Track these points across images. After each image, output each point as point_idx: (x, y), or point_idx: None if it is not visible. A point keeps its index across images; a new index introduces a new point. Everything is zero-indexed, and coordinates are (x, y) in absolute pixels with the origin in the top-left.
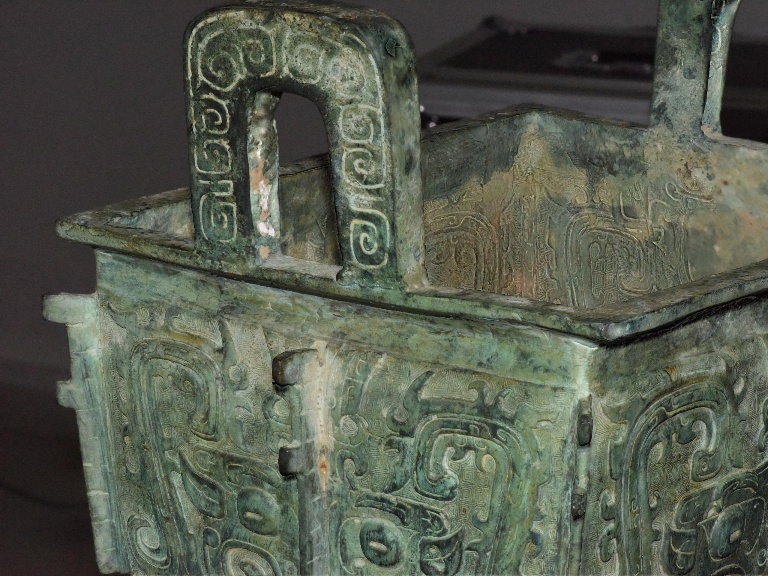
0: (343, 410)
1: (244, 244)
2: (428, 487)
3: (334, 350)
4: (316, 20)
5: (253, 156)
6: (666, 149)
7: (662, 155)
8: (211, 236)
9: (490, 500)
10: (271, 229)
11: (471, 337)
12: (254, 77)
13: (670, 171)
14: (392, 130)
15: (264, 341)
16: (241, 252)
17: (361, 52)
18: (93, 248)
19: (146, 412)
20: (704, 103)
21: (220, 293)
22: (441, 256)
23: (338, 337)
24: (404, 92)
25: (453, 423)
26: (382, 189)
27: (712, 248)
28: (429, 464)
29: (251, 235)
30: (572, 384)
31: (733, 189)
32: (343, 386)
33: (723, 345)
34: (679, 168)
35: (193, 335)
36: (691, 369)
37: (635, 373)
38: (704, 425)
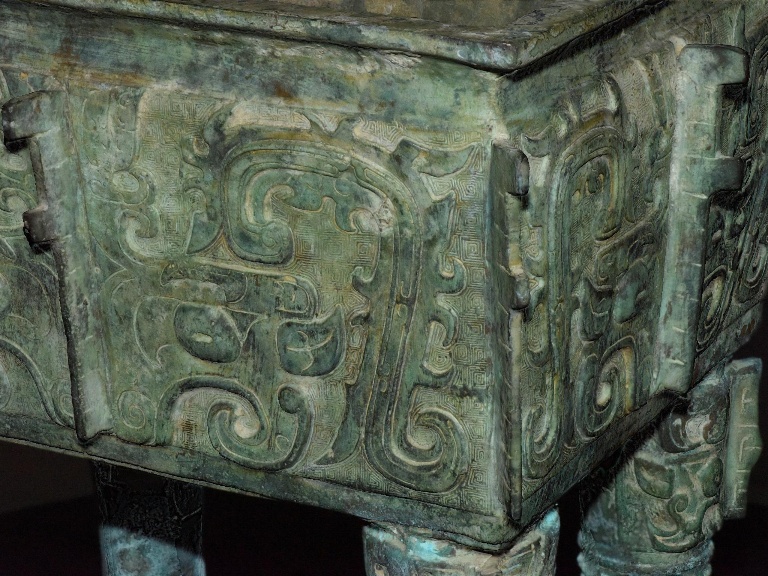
0: None
1: None
2: None
3: None
4: None
5: None
6: None
7: None
8: None
9: None
10: None
11: None
12: None
13: None
14: None
15: None
16: None
17: None
18: None
19: None
20: None
21: None
22: None
23: (675, 25)
24: None
25: None
26: None
27: None
28: (752, 107)
29: None
30: None
31: None
32: None
33: None
34: None
35: None
36: None
37: None
38: None
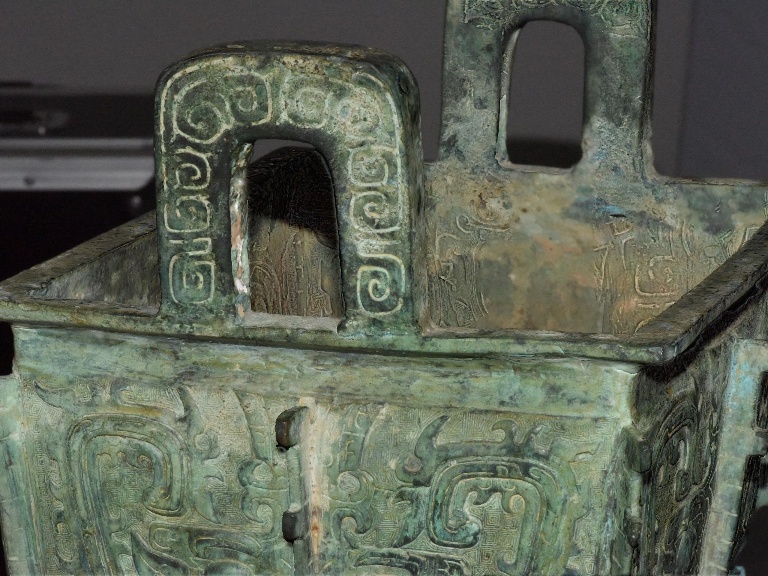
0: (342, 467)
1: (224, 303)
2: (447, 536)
3: (326, 405)
4: (323, 61)
5: (232, 210)
6: (457, 182)
7: (452, 188)
8: (182, 298)
9: (519, 541)
10: (243, 286)
11: (487, 377)
12: (244, 126)
13: (462, 203)
14: (410, 170)
15: (237, 404)
16: (219, 312)
17: (377, 91)
18: (17, 325)
19: (88, 494)
20: (497, 132)
21: (175, 359)
22: None
23: (326, 392)
24: (415, 130)
25: (477, 467)
26: (397, 232)
27: (507, 277)
28: (448, 512)
29: (232, 293)
30: (614, 413)
31: (532, 216)
32: (340, 442)
33: (689, 363)
34: (472, 200)
35: (148, 406)
36: (677, 389)
37: (652, 397)
38: (683, 444)
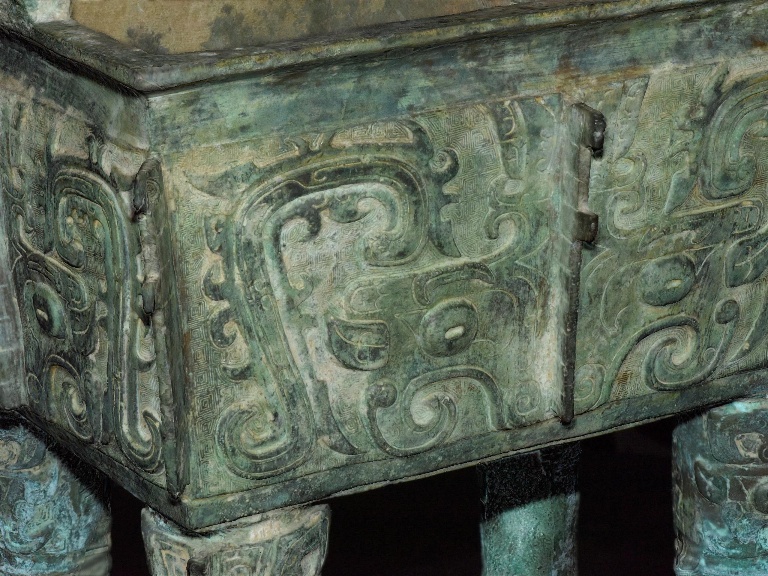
0: None
1: None
2: None
3: None
4: None
5: None
6: None
7: None
8: None
9: None
10: None
11: None
12: None
13: None
14: None
15: None
16: None
17: None
18: None
19: None
20: None
21: None
22: (348, 214)
23: None
24: None
25: None
26: None
27: None
28: None
29: None
30: None
31: None
32: None
33: None
34: None
35: None
36: None
37: None
38: None
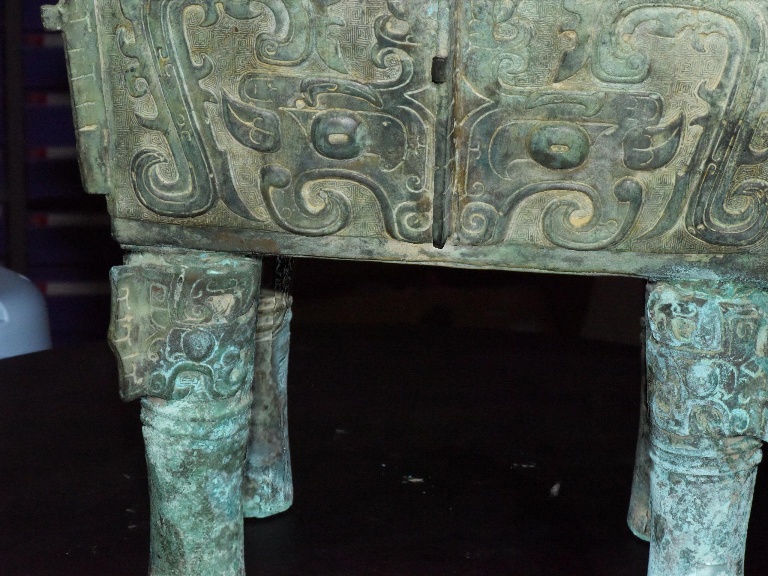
0: None
1: None
2: None
3: None
4: None
5: None
6: None
7: None
8: None
9: None
10: None
11: None
12: None
13: None
14: None
15: None
16: None
17: None
18: None
19: None
20: None
21: None
22: None
23: None
24: None
25: None
26: None
27: None
28: None
29: None
30: None
31: None
32: None
33: None
34: None
35: None
36: None
37: None
38: (271, 10)
